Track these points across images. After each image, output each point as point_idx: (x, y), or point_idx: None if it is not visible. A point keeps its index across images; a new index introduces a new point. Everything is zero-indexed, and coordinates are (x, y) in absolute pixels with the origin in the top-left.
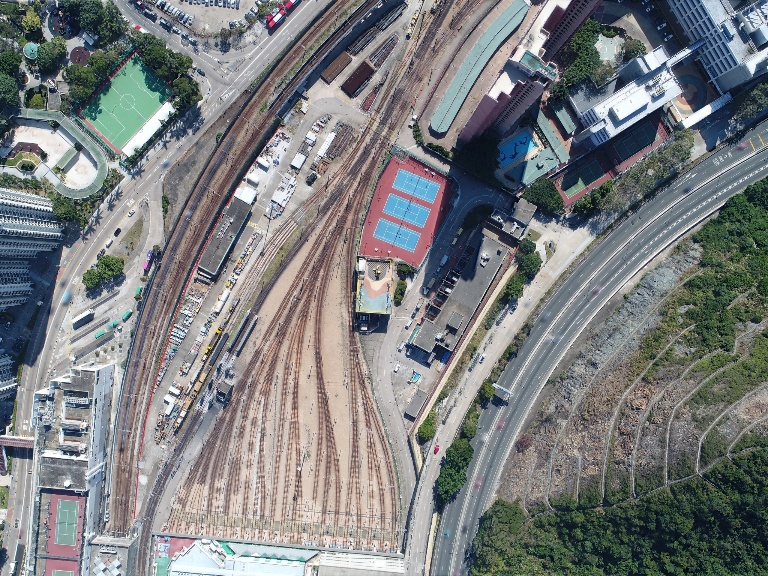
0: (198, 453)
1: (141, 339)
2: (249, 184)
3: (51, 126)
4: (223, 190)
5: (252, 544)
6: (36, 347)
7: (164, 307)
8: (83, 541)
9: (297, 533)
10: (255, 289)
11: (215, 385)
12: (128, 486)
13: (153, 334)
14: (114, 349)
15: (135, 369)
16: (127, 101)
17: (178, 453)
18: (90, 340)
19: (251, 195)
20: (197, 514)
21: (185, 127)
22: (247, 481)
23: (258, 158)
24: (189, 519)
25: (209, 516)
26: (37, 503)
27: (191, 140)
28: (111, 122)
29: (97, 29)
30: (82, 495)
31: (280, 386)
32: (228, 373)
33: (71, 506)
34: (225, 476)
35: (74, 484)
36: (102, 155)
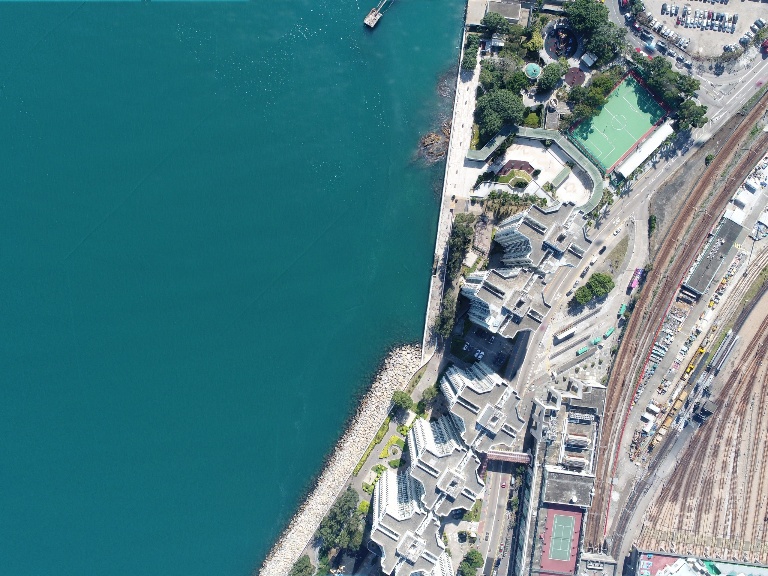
0: (672, 471)
1: (621, 356)
2: (735, 205)
3: (544, 145)
4: (715, 211)
5: (737, 564)
6: (516, 362)
7: (647, 325)
8: (578, 557)
9: (766, 554)
10: (736, 309)
11: (692, 404)
12: (600, 502)
13: (635, 352)
14: (594, 366)
15: (613, 386)
16: (618, 121)
17: (651, 471)
18: (570, 356)
19: (741, 216)
20: (668, 532)
21: (675, 148)
22: (719, 500)
23: (747, 180)
24: (659, 537)
25: (679, 534)
26: (534, 517)
27: (680, 161)
28: (602, 142)
29: (603, 51)
30: (587, 511)
31: (756, 406)
32: (707, 392)
33: (567, 521)
34: (697, 495)
35: (578, 500)
36: (599, 174)
